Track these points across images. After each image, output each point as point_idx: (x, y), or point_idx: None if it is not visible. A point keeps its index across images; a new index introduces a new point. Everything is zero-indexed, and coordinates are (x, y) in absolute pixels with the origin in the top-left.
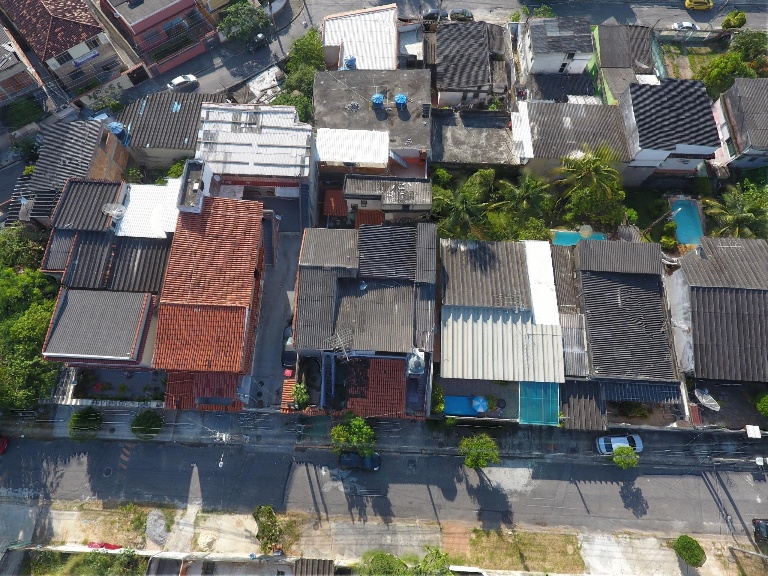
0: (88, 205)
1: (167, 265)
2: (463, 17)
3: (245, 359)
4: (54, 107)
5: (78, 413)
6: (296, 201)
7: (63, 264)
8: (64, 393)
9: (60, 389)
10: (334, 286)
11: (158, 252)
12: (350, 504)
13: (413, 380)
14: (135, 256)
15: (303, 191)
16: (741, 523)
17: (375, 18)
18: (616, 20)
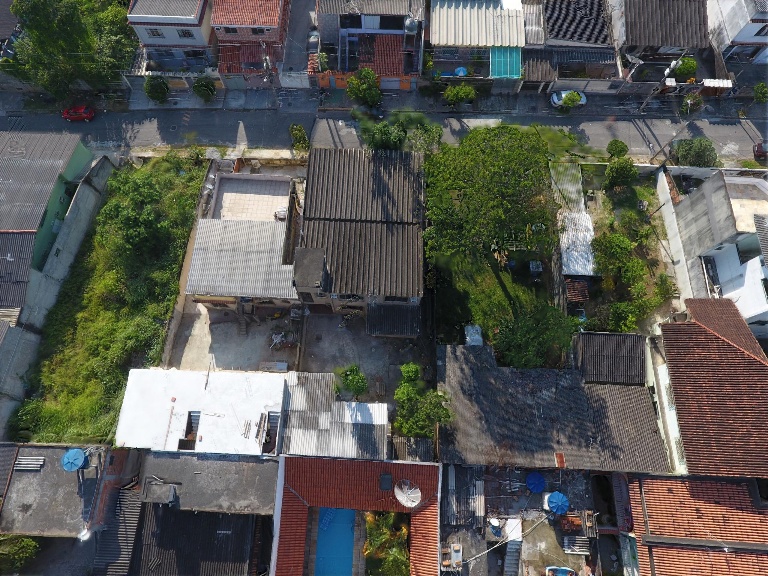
0: None
1: None
2: None
3: (280, 35)
4: None
5: (151, 77)
6: None
7: None
8: (139, 68)
9: (136, 66)
10: None
11: None
12: (361, 142)
13: (409, 54)
14: None
15: None
16: (660, 148)
17: None
18: None
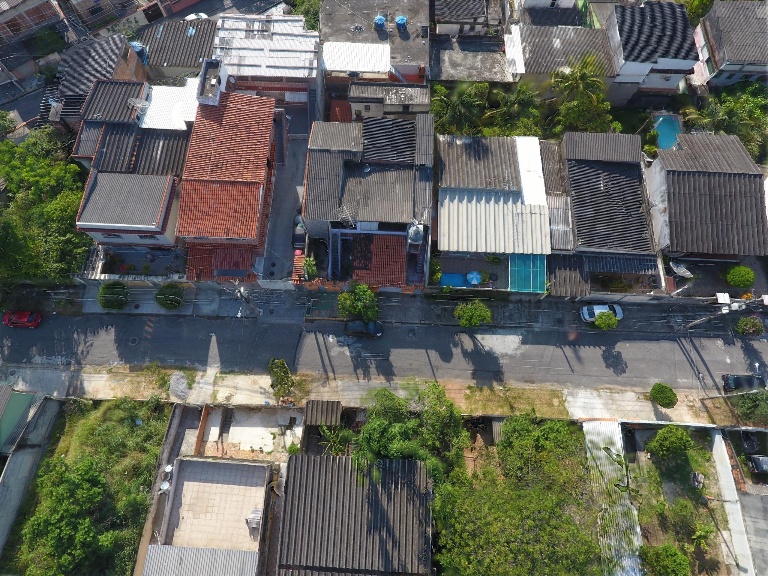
0: (114, 101)
1: (188, 148)
2: None
3: (259, 235)
4: (75, 38)
5: (107, 285)
6: (304, 105)
7: (92, 151)
8: (93, 269)
9: (90, 266)
10: (340, 167)
11: (179, 143)
12: (355, 366)
13: (413, 256)
14: (158, 146)
15: (311, 96)
16: (712, 380)
17: None
18: None
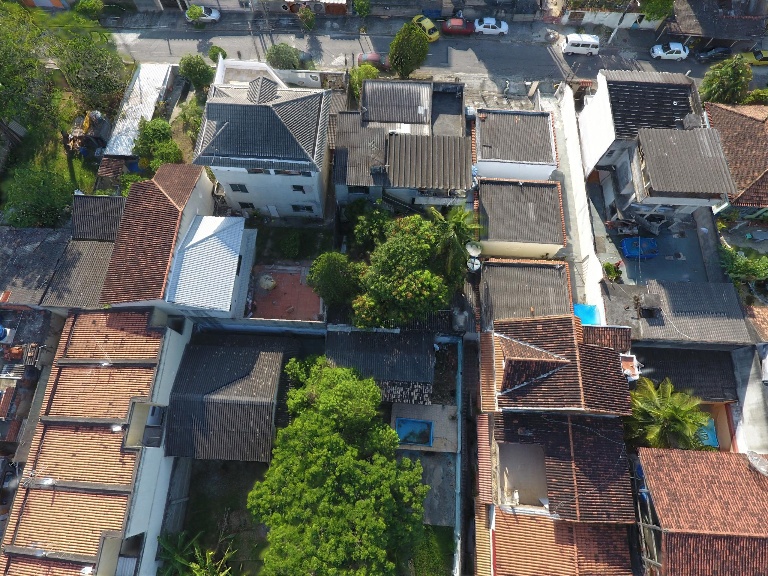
0: None
1: None
2: None
3: None
4: None
5: None
6: None
7: None
8: None
9: None
10: None
11: None
12: None
13: None
14: None
15: None
16: None
17: None
18: None
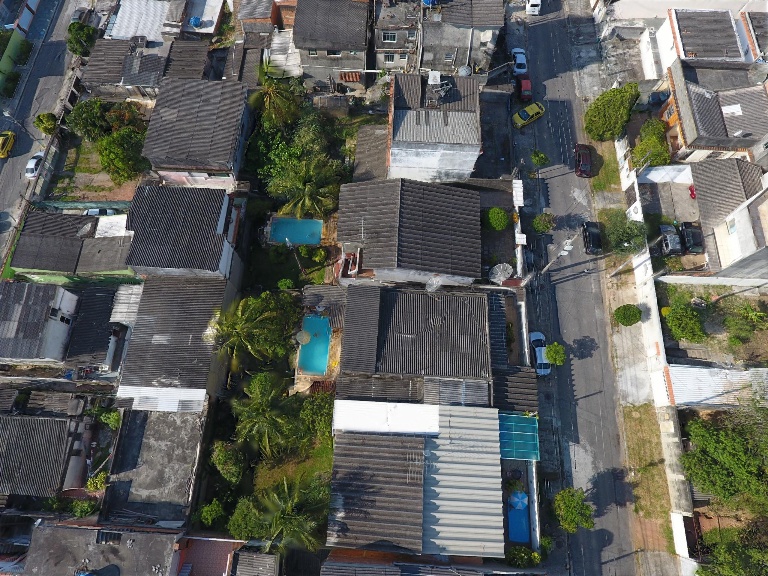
0: None
1: None
2: None
3: None
4: None
5: None
6: None
7: None
8: None
9: None
10: None
11: None
12: None
13: None
14: None
15: None
16: None
17: None
18: None
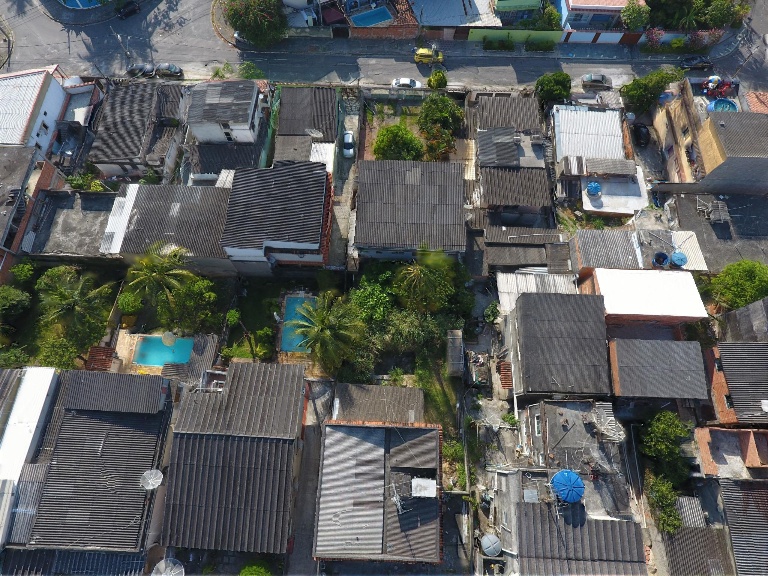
0: None
1: None
2: (169, 72)
3: None
4: None
5: None
6: None
7: None
8: None
9: None
10: None
11: None
12: None
13: None
14: None
15: None
16: None
17: (18, 83)
18: (337, 75)
